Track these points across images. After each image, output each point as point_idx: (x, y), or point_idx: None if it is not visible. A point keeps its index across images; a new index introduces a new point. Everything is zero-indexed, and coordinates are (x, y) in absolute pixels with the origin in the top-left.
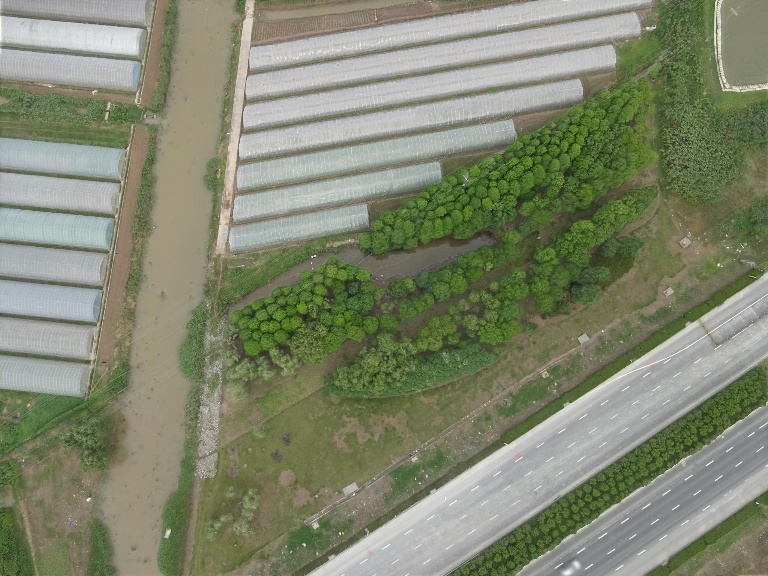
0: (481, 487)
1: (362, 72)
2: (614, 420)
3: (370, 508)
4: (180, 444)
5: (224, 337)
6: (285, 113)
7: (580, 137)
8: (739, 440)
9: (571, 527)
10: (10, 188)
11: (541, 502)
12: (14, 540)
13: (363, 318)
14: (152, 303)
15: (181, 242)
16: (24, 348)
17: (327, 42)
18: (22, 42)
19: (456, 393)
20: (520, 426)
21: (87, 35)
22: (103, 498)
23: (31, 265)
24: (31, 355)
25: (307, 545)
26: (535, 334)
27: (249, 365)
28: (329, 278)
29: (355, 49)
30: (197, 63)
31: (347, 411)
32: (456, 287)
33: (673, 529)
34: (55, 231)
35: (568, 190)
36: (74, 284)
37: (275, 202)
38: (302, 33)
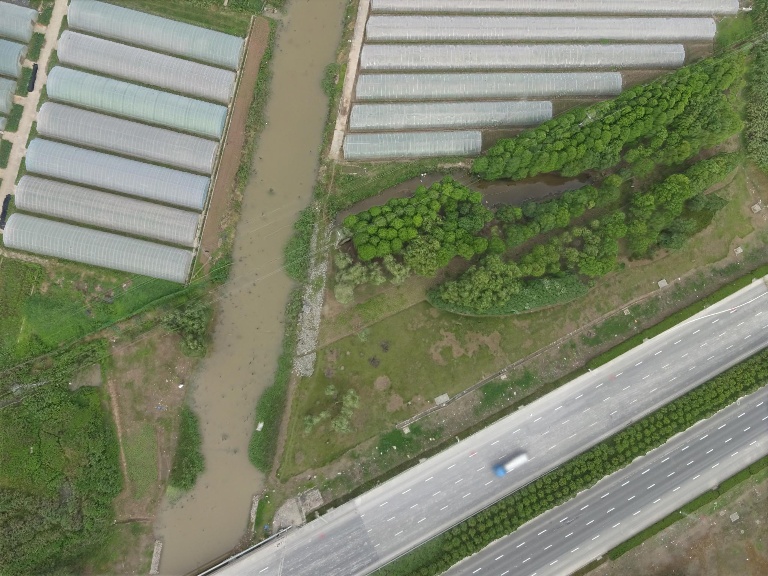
0: (564, 407)
1: (487, 2)
2: (684, 358)
3: (460, 418)
4: (278, 341)
5: (331, 241)
6: (408, 30)
7: (686, 96)
8: None
9: (642, 449)
10: (122, 58)
11: (615, 425)
12: (101, 419)
13: (473, 238)
14: (260, 199)
15: (293, 142)
16: (125, 226)
17: None
18: None
19: (547, 320)
20: (604, 355)
21: None
22: (196, 386)
23: (140, 141)
24: (130, 235)
25: (397, 448)
26: (621, 274)
27: (363, 268)
28: (445, 195)
29: None
30: None
31: (445, 326)
32: (562, 220)
33: (724, 459)
34: (168, 110)
35: (670, 144)
36: (181, 168)
37: (392, 116)
38: None
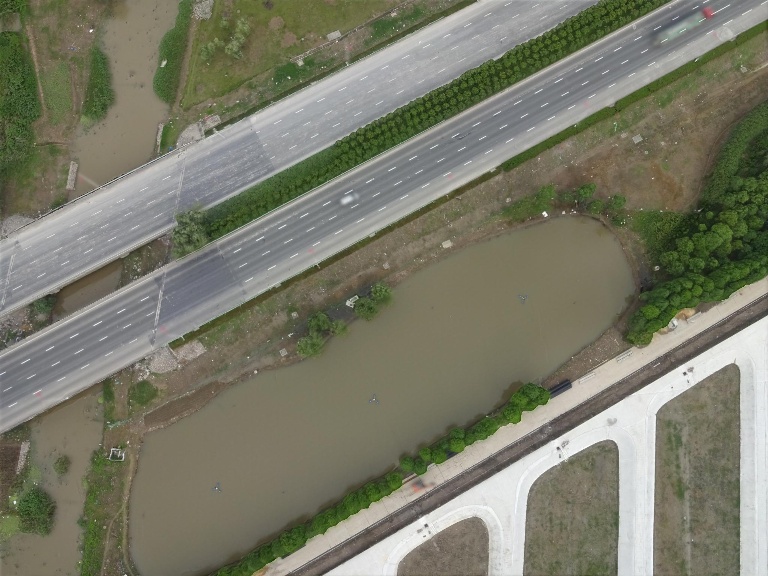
0: (452, 35)
1: None
2: None
3: (351, 50)
4: None
5: None
6: None
7: None
8: (684, 11)
9: (531, 64)
10: None
11: (505, 50)
12: (20, 57)
13: None
14: None
15: None
16: None
17: None
18: None
19: None
20: None
21: None
22: (105, 31)
23: None
24: None
25: (292, 78)
26: None
27: None
28: None
29: None
30: None
31: None
32: None
33: (621, 79)
34: None
35: None
36: None
37: None
38: None
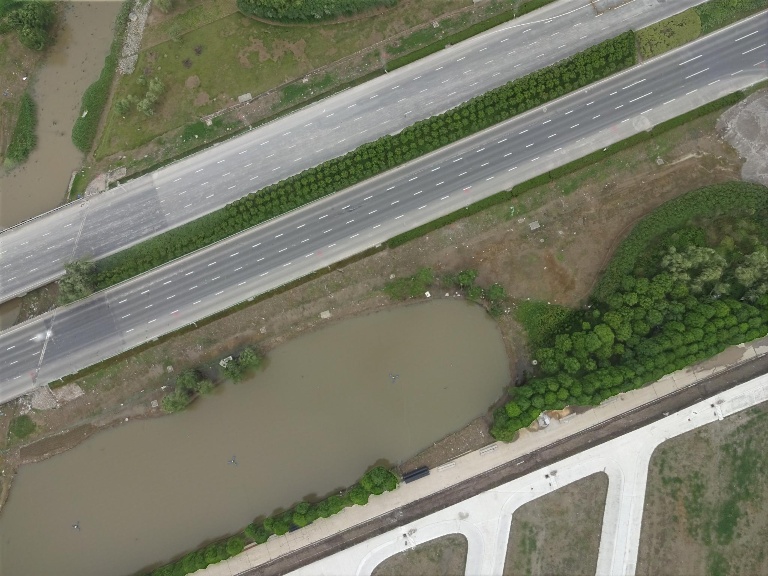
0: (357, 105)
1: None
2: (489, 65)
3: (258, 113)
4: (108, 45)
5: None
6: None
7: None
8: (601, 96)
9: (428, 142)
10: None
11: (408, 125)
12: None
13: None
14: None
15: None
16: None
17: None
18: None
19: (353, 30)
20: (402, 58)
21: None
22: (37, 80)
23: None
24: None
25: (199, 137)
26: None
27: None
28: None
29: None
30: None
31: (254, 33)
32: None
33: (523, 163)
34: None
35: None
36: None
37: None
38: None
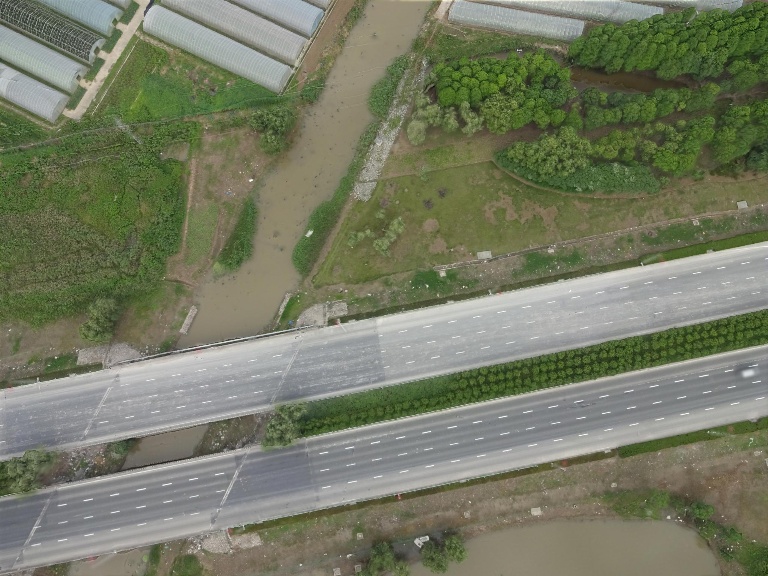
0: (606, 293)
1: None
2: (749, 281)
3: (497, 276)
4: (346, 164)
5: (417, 88)
6: None
7: None
8: None
9: (680, 353)
10: None
11: (657, 326)
12: (177, 188)
13: (552, 109)
14: (363, 39)
15: None
16: (243, 33)
17: None
18: None
19: (609, 209)
20: (661, 253)
21: None
22: (264, 184)
23: None
24: (244, 44)
25: (430, 287)
26: (699, 185)
27: (439, 109)
28: (534, 64)
29: None
30: None
31: (505, 188)
32: (646, 111)
33: None
34: None
35: None
36: None
37: None
38: None
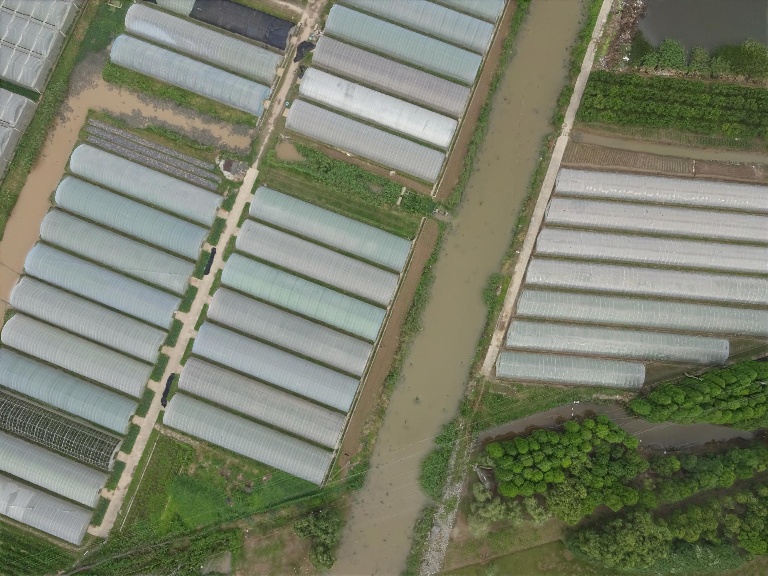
0: None
1: (670, 225)
2: None
3: None
4: (403, 556)
5: (470, 461)
6: (580, 246)
7: None
8: None
9: None
10: (294, 254)
11: None
12: None
13: (623, 487)
14: (405, 406)
15: (445, 351)
16: (274, 421)
17: (640, 183)
18: (333, 103)
19: None
20: None
21: (402, 114)
22: None
23: (299, 339)
24: (276, 428)
25: None
26: None
27: (502, 507)
28: (599, 438)
29: (667, 198)
30: (500, 168)
31: (578, 571)
32: (725, 482)
33: None
34: (330, 311)
35: None
36: (333, 367)
37: (551, 337)
38: (615, 166)
